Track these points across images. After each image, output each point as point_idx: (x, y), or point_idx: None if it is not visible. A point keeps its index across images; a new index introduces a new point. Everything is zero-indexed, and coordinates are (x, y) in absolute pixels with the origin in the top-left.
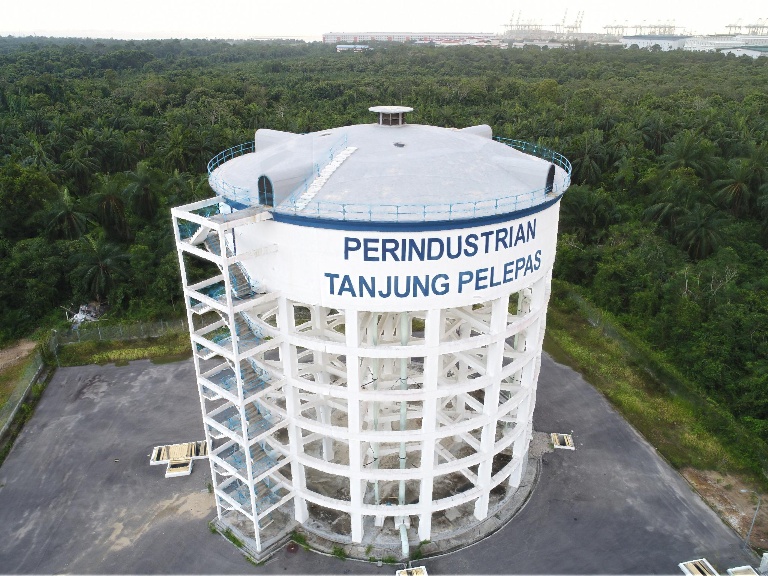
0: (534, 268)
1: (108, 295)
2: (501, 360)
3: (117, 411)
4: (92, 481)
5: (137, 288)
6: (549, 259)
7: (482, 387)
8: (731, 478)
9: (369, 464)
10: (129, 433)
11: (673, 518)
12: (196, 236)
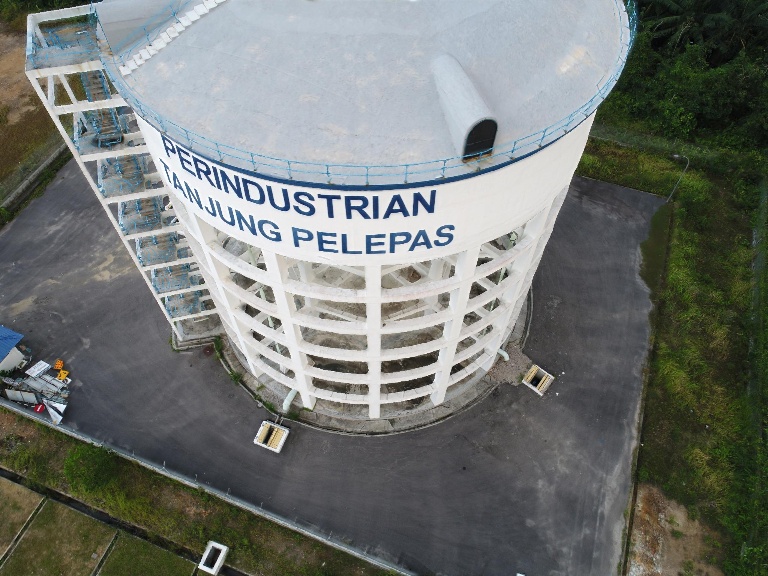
0: (436, 243)
1: None
2: (378, 319)
3: None
4: None
5: None
6: (487, 231)
7: None
8: (696, 526)
9: None
10: None
11: (567, 528)
12: None
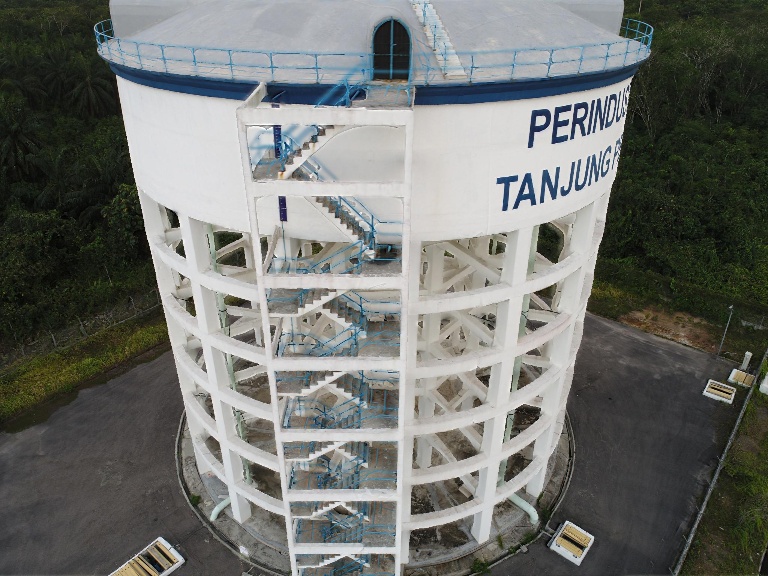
0: None
1: None
2: None
3: None
4: None
5: None
6: None
7: None
8: (647, 311)
9: (442, 445)
10: None
11: (659, 360)
12: (305, 158)
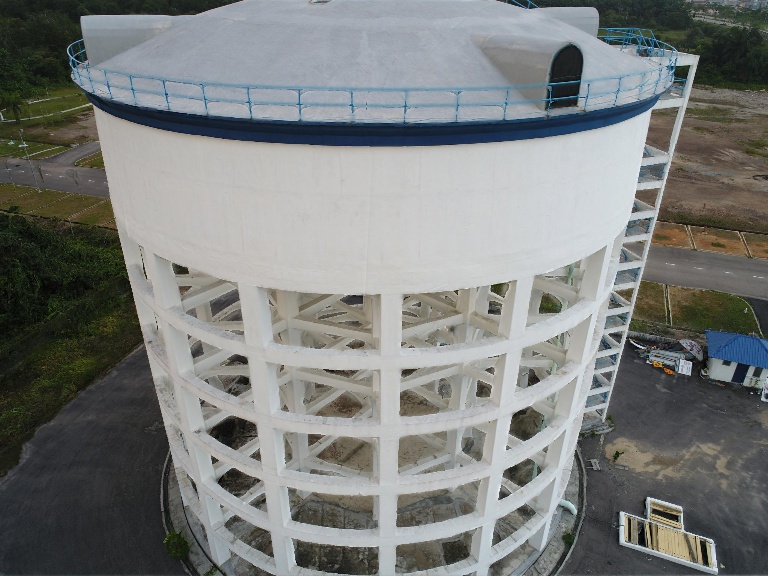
0: None
1: None
2: None
3: None
4: None
5: None
6: None
7: None
8: None
9: None
10: None
11: (236, 299)
12: None
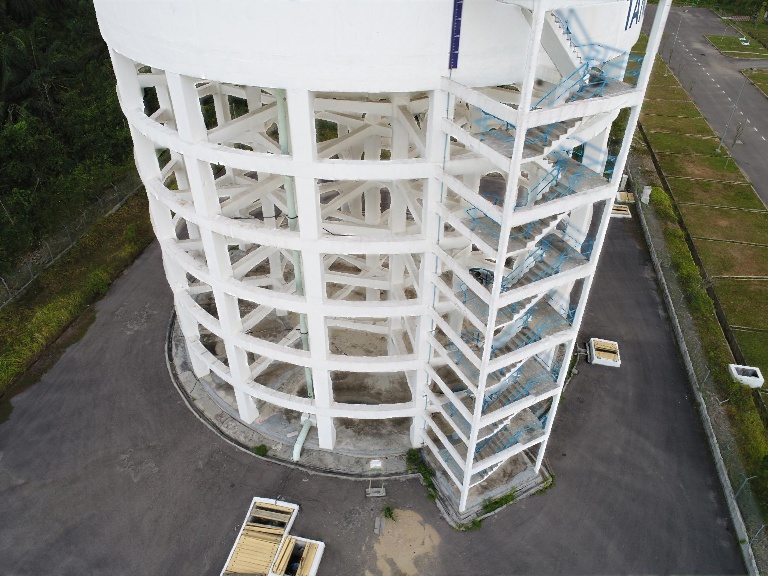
0: None
1: None
2: None
3: None
4: None
5: None
6: None
7: None
8: None
9: None
10: None
11: None
12: None
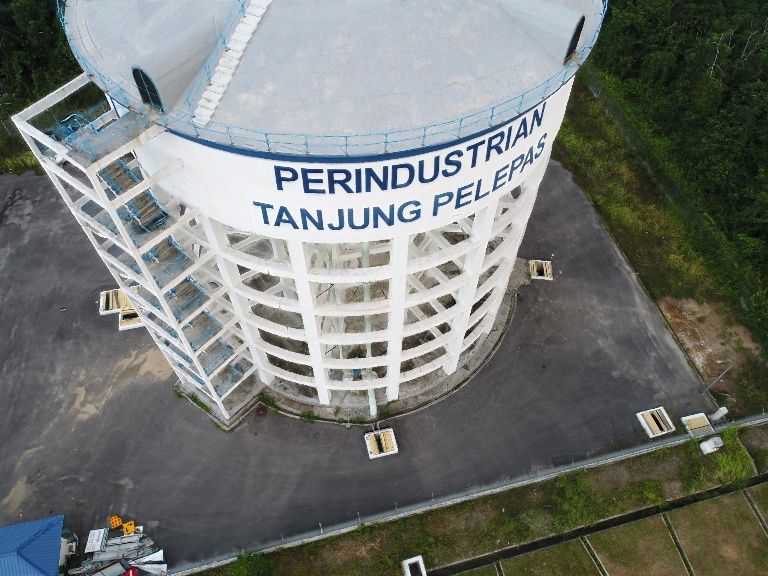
0: (535, 157)
1: (1, 68)
2: (482, 259)
3: (50, 242)
4: (41, 337)
5: (36, 56)
6: (556, 130)
7: (457, 288)
8: (707, 307)
9: None
10: (70, 272)
11: (640, 361)
12: (61, 158)
